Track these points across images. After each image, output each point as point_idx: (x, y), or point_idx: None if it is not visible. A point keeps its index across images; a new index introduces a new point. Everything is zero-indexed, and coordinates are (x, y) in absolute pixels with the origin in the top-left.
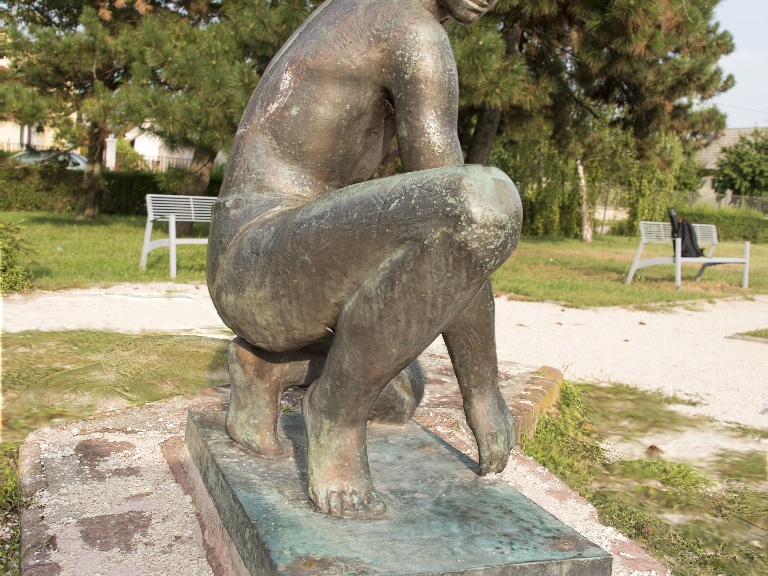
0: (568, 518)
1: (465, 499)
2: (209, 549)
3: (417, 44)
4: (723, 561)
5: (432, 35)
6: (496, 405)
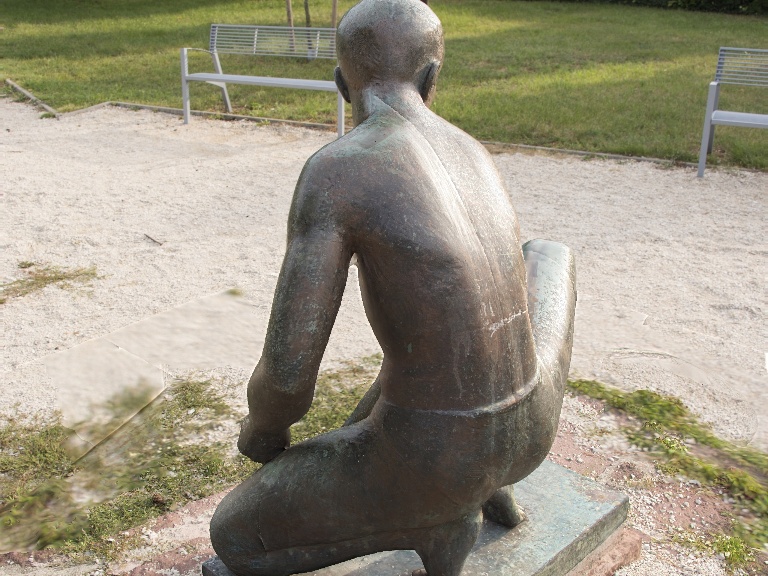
0: None
1: None
2: None
3: None
4: (206, 460)
5: None
6: None
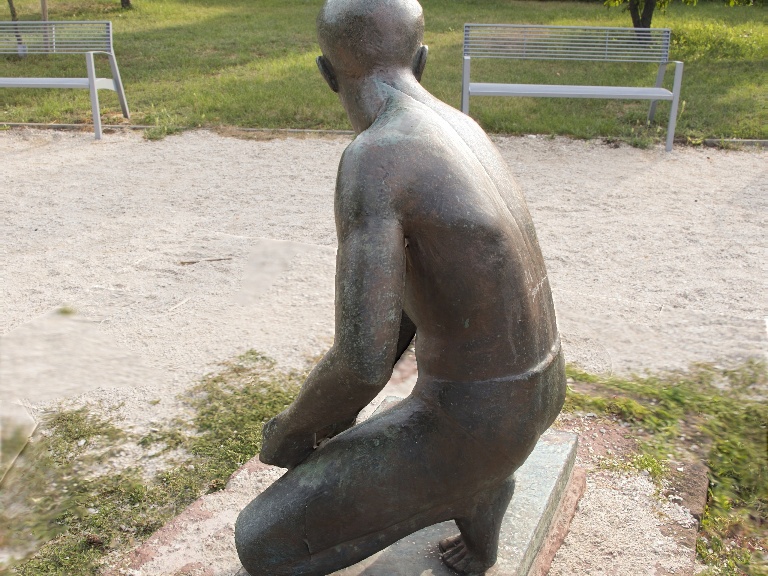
0: None
1: None
2: (544, 572)
3: None
4: (127, 489)
5: None
6: None
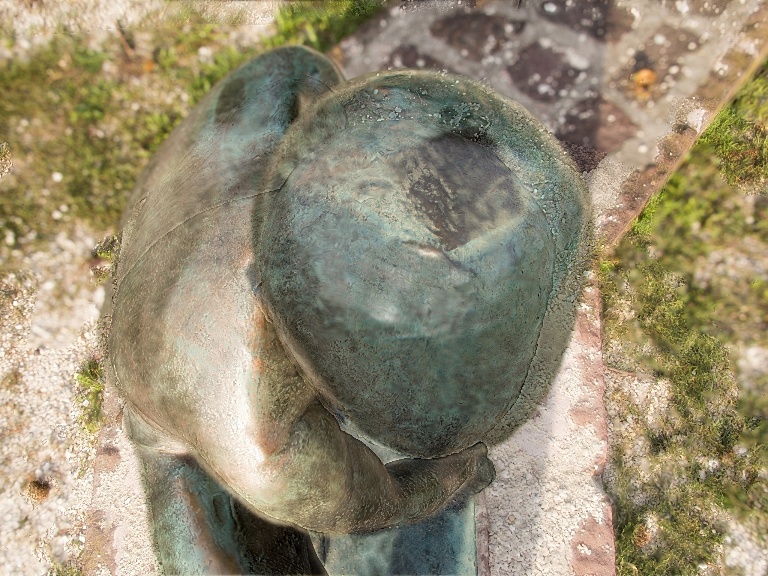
0: (567, 463)
1: (413, 540)
2: None
3: (247, 498)
4: (734, 488)
5: (269, 498)
6: (465, 485)
